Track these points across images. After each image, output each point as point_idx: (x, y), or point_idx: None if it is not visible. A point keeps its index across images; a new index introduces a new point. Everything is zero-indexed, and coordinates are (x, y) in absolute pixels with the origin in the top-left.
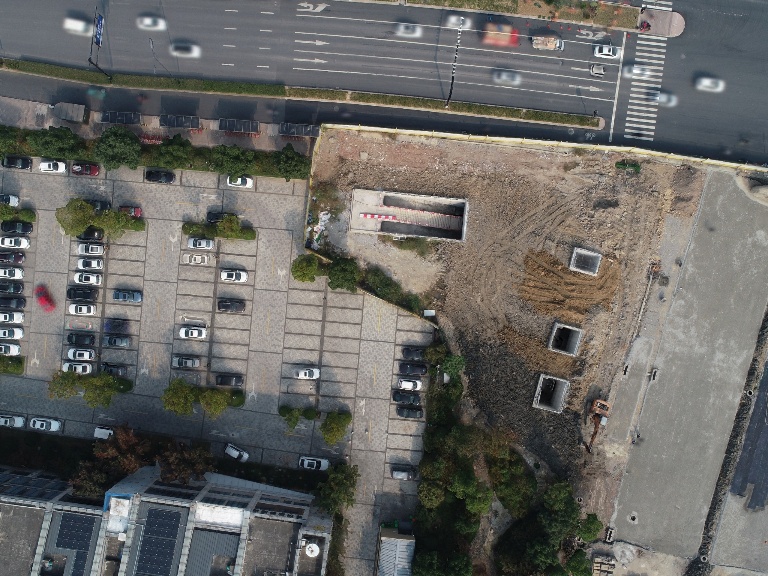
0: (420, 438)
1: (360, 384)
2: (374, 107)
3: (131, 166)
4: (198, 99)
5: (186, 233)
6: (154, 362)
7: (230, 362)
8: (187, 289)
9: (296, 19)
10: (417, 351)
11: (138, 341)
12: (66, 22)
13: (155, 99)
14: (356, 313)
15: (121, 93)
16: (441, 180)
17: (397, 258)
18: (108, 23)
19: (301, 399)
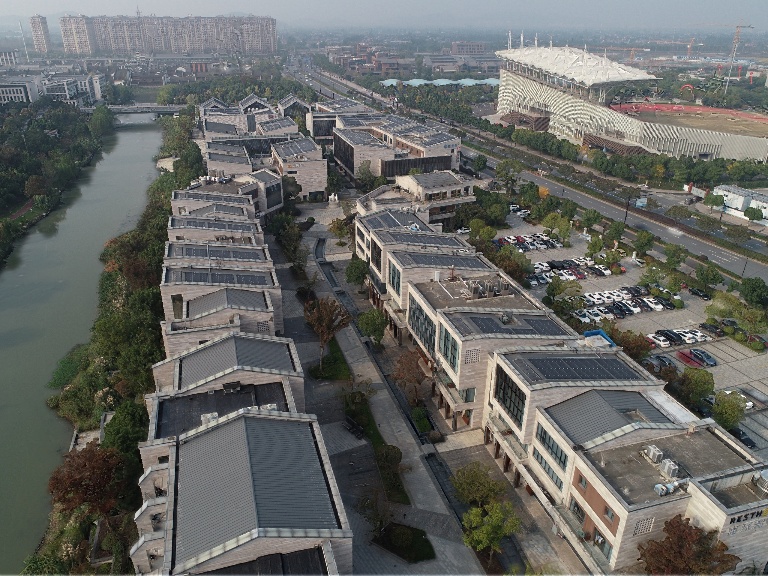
0: None
1: None
2: None
3: None
4: None
5: None
6: None
7: (752, 433)
8: (760, 387)
9: None
10: None
11: None
12: None
13: None
14: None
15: None
16: None
17: None
18: None
19: None
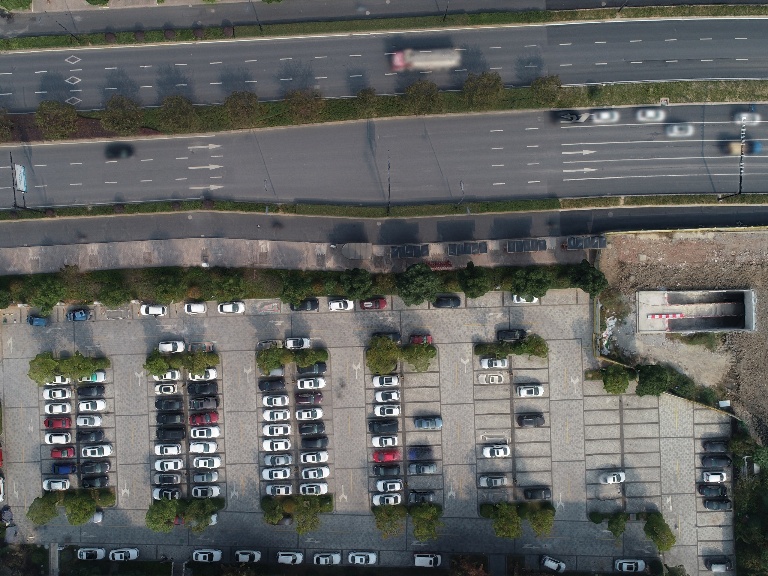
0: (729, 527)
1: (664, 481)
2: (647, 208)
3: (432, 300)
4: (473, 221)
5: (478, 354)
6: (460, 484)
7: (534, 475)
8: (484, 408)
9: (561, 131)
10: (720, 444)
11: (442, 465)
12: (335, 161)
13: (431, 226)
14: (652, 412)
15: (397, 224)
16: (721, 272)
17: (686, 354)
18: (376, 157)
19: (608, 503)
